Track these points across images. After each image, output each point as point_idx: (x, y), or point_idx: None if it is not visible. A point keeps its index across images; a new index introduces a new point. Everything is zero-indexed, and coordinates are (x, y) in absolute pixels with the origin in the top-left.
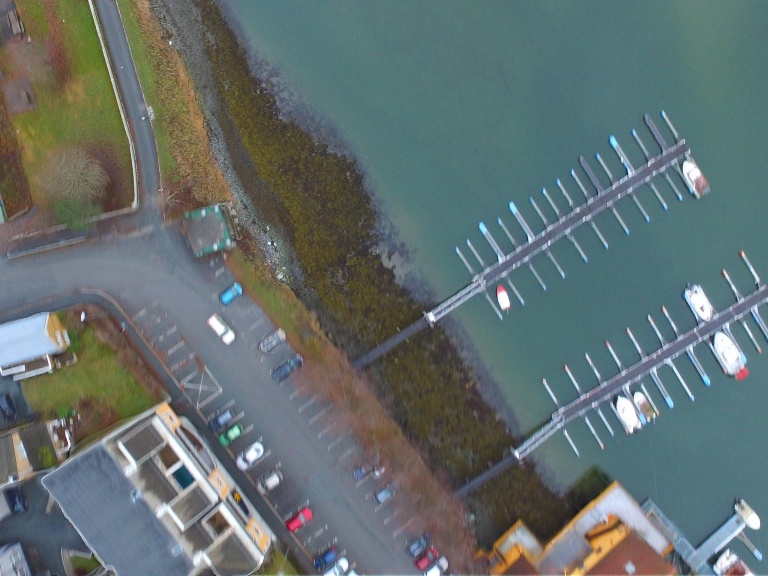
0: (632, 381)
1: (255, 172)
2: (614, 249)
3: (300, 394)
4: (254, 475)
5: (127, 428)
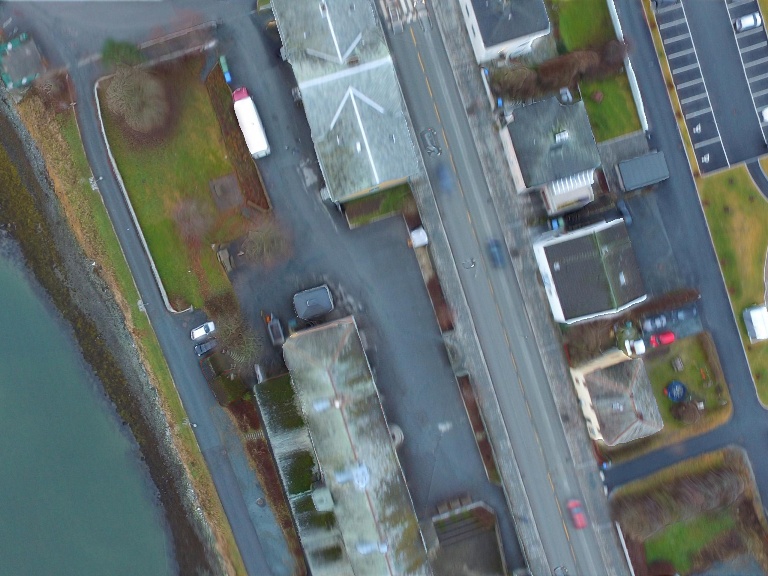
0: None
1: (2, 140)
2: None
3: None
4: None
5: None
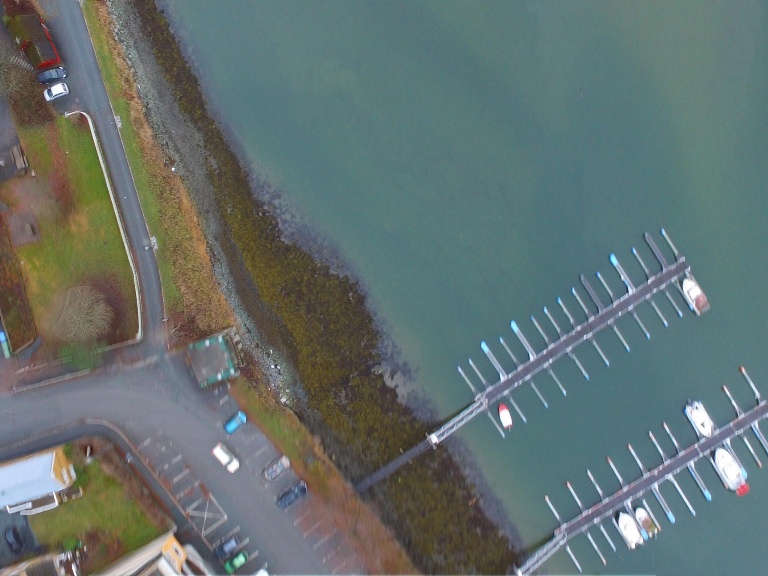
0: (634, 497)
1: (258, 295)
2: (615, 366)
3: (304, 520)
4: None
5: (134, 573)
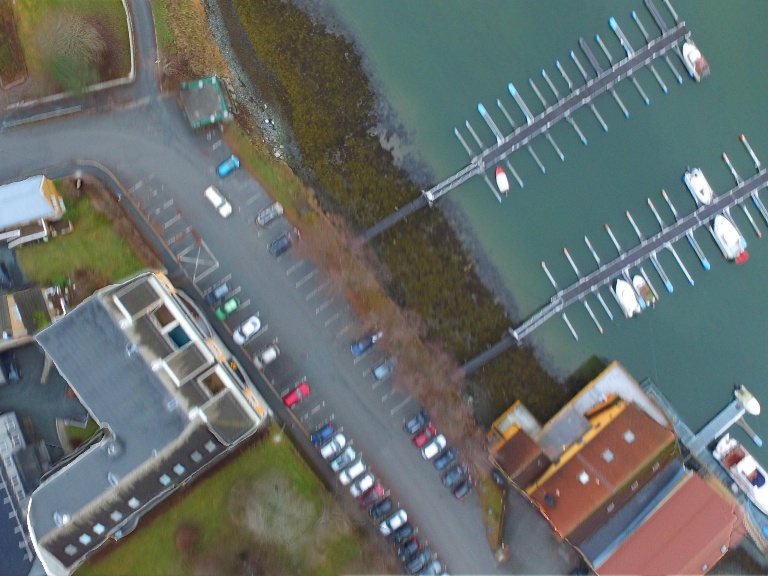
0: (631, 265)
1: (253, 50)
2: (614, 132)
3: (297, 269)
4: (251, 350)
5: (122, 284)
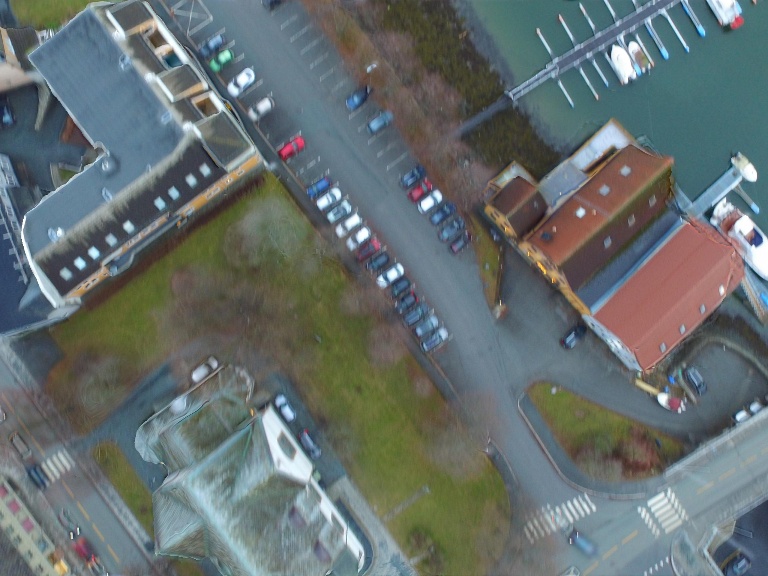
0: (627, 31)
1: None
2: None
3: (291, 24)
4: (245, 103)
5: None
